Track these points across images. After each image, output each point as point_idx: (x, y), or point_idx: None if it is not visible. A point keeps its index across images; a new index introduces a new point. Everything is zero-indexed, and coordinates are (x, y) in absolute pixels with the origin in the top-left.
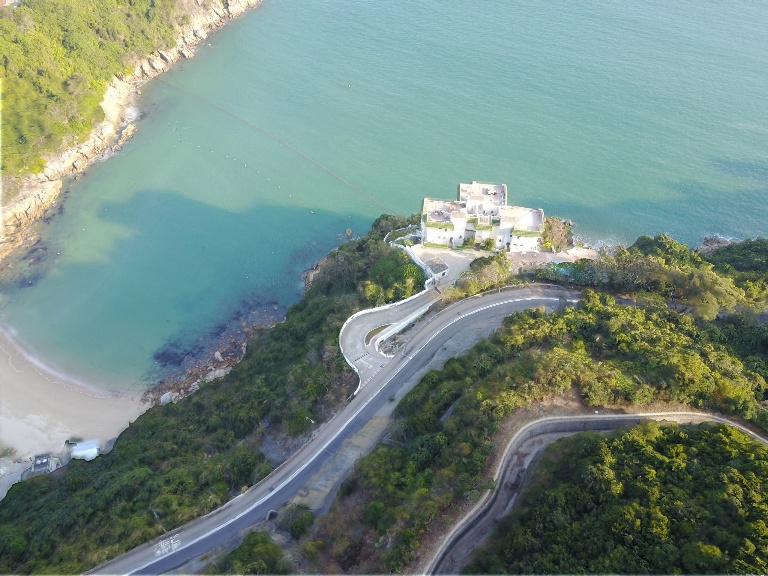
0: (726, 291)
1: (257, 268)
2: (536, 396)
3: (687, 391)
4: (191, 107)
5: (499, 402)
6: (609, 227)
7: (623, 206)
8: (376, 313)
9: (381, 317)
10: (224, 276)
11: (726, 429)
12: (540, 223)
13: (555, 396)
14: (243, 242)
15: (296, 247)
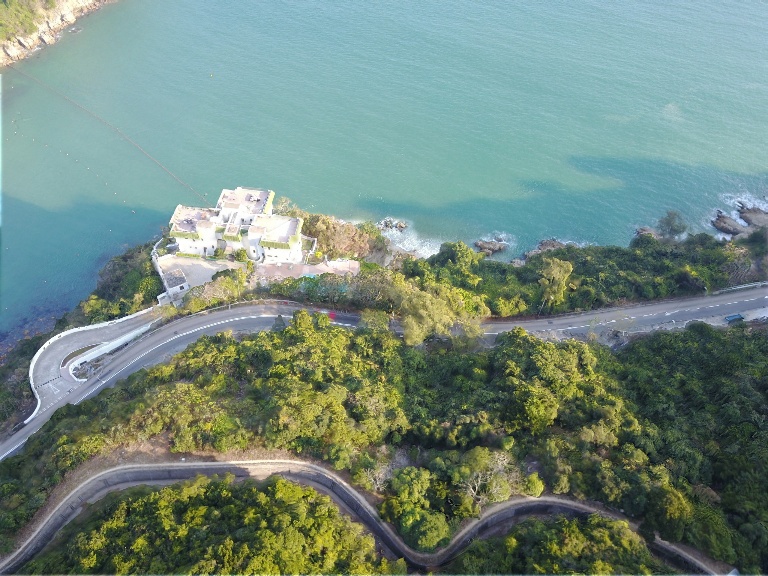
0: (429, 315)
1: (59, 271)
2: (123, 441)
3: (279, 438)
4: (38, 97)
5: (75, 448)
6: (444, 229)
7: (465, 206)
8: (90, 331)
9: (94, 336)
10: (23, 280)
11: (275, 487)
12: (294, 233)
13: (145, 441)
14: (53, 243)
15: (107, 249)
